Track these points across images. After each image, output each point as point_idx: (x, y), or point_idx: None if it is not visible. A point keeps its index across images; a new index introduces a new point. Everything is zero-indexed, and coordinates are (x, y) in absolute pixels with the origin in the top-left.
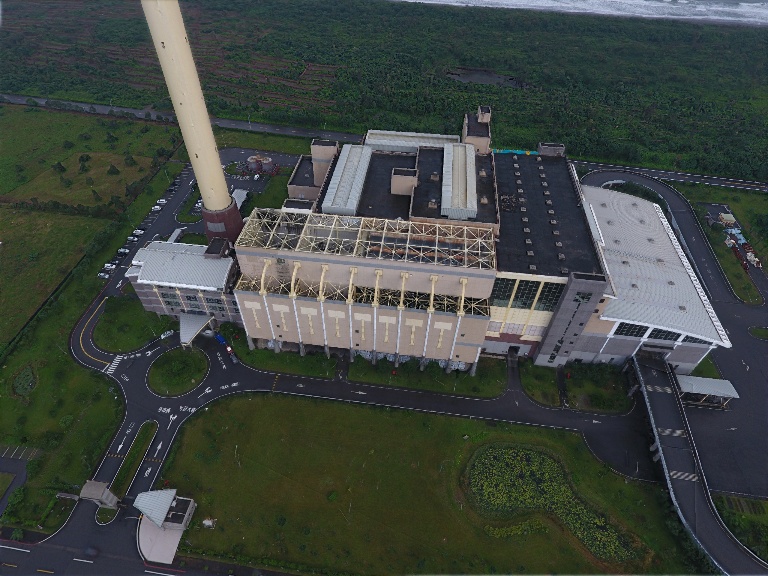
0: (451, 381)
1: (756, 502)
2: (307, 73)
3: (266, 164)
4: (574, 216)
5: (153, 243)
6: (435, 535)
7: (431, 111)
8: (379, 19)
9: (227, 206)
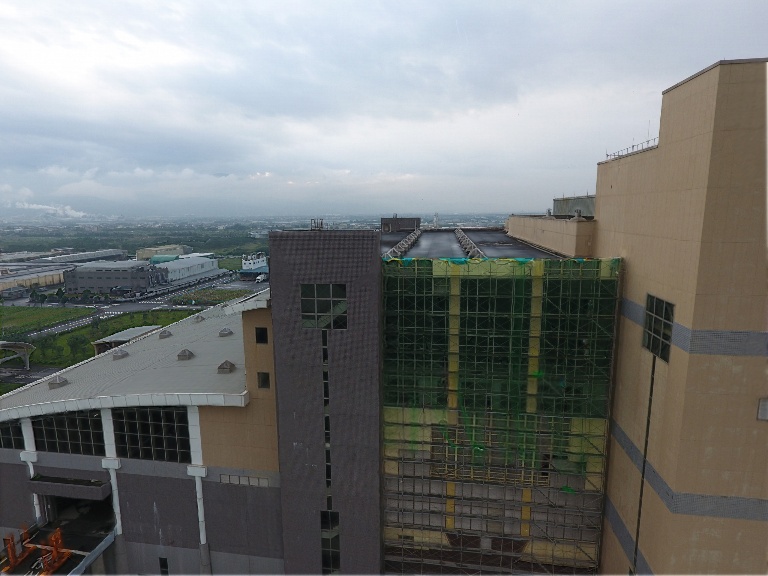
0: None
1: None
2: None
3: None
4: None
5: None
6: None
7: None
8: None
9: None
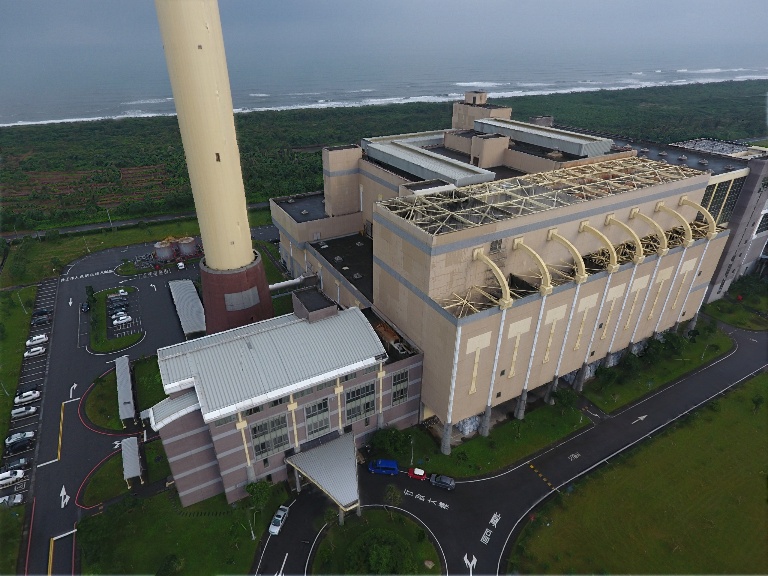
0: (686, 352)
1: None
2: (126, 176)
3: (189, 244)
4: (645, 146)
5: (162, 352)
6: None
7: (318, 171)
8: (168, 129)
9: (253, 257)
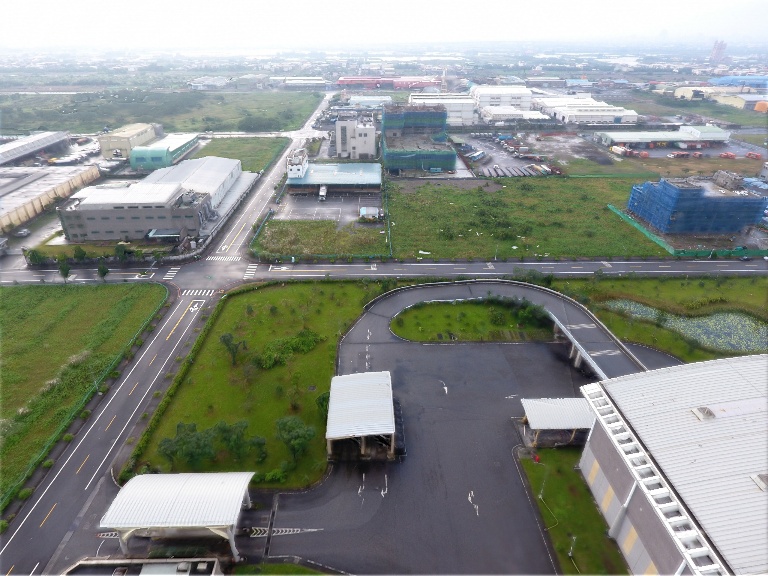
0: None
1: (498, 336)
2: None
3: None
4: None
5: None
6: (761, 296)
7: None
8: None
9: None
